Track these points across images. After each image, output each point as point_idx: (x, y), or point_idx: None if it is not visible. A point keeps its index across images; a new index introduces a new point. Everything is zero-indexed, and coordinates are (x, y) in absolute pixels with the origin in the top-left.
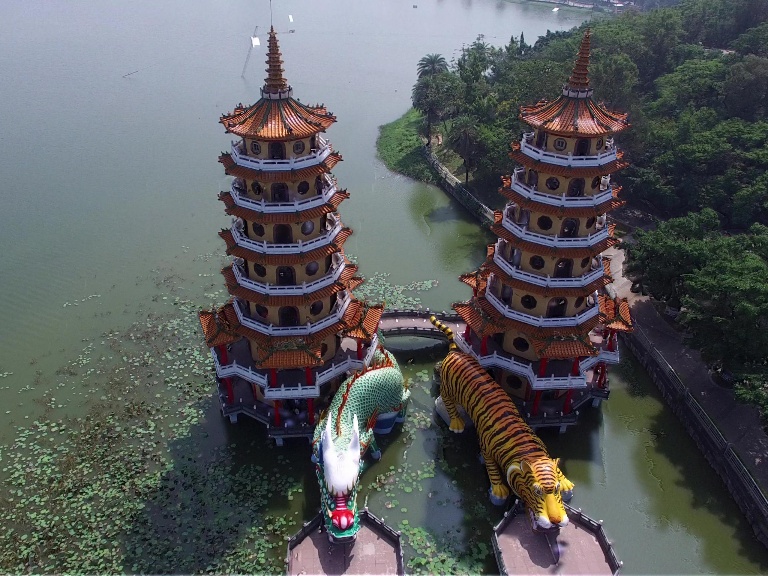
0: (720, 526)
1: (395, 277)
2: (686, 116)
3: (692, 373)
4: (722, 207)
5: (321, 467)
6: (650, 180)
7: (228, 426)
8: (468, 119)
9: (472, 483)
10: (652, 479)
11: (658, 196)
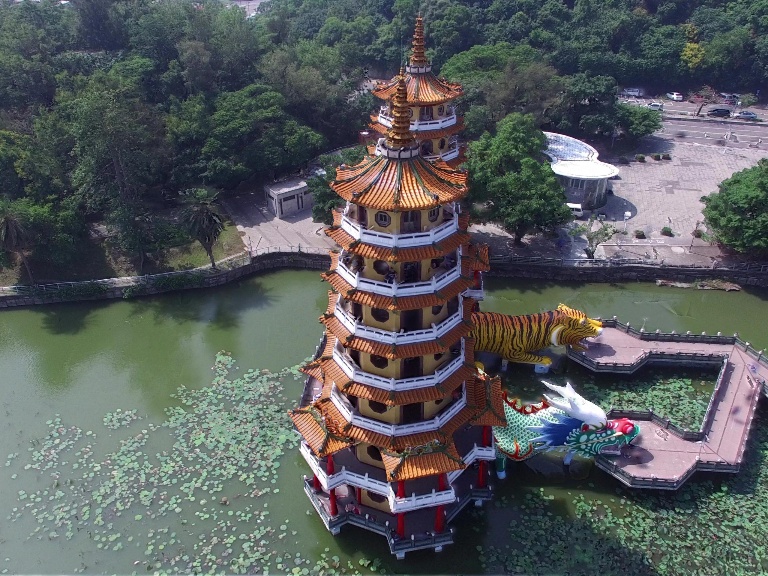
0: (553, 290)
1: (191, 382)
2: (187, 107)
3: None
4: (284, 159)
5: (585, 424)
6: (225, 167)
7: (429, 567)
8: (2, 203)
9: (527, 380)
10: (516, 302)
11: (236, 177)
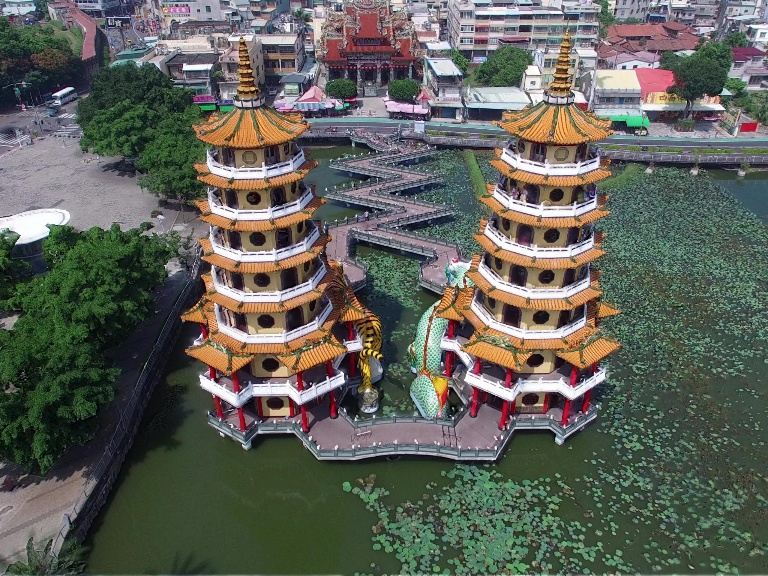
0: None
1: None
2: None
3: (122, 375)
4: None
5: None
6: None
7: None
8: None
9: None
10: None
11: None
